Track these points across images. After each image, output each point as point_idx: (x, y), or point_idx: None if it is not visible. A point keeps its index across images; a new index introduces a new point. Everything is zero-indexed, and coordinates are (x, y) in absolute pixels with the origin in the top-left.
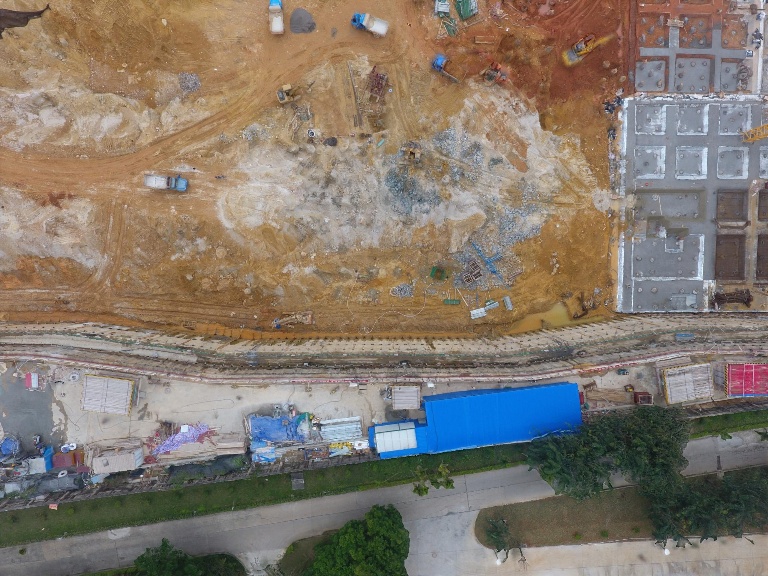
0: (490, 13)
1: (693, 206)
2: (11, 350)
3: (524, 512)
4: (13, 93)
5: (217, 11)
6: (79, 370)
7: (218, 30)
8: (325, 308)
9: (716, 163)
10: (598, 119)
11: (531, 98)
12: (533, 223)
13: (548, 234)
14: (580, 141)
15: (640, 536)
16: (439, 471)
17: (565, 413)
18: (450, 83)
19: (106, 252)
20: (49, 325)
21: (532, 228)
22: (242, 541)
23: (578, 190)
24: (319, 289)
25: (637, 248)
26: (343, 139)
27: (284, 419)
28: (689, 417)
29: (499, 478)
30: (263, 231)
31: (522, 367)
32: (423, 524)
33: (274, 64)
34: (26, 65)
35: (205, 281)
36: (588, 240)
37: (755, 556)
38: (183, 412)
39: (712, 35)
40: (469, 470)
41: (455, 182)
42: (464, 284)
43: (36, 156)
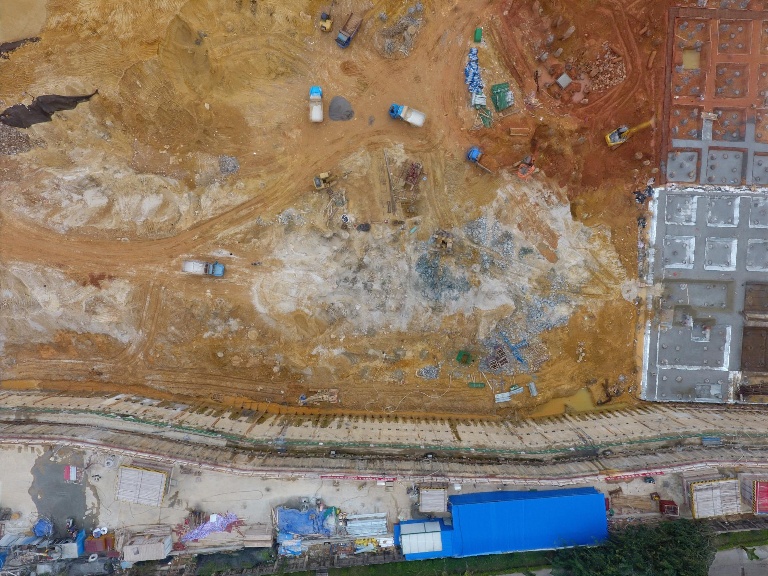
0: (525, 102)
1: (721, 296)
2: (49, 434)
3: None
4: (59, 174)
5: (259, 97)
6: (113, 456)
7: (259, 115)
8: (351, 386)
9: (745, 255)
10: (628, 208)
11: (563, 187)
12: (561, 314)
13: (576, 325)
14: (610, 232)
15: None
16: (462, 571)
17: (591, 523)
18: (484, 173)
19: (141, 328)
20: (83, 400)
21: (560, 318)
22: None
23: (607, 282)
24: (346, 368)
25: (663, 336)
26: (376, 225)
27: (311, 513)
28: (715, 532)
29: None
30: (295, 317)
31: (547, 465)
32: None
33: (312, 150)
34: (72, 145)
35: (235, 359)
36: (615, 330)
37: None
38: (212, 501)
39: (746, 129)
40: (492, 572)
41: (485, 269)
42: (489, 368)
43: (79, 238)
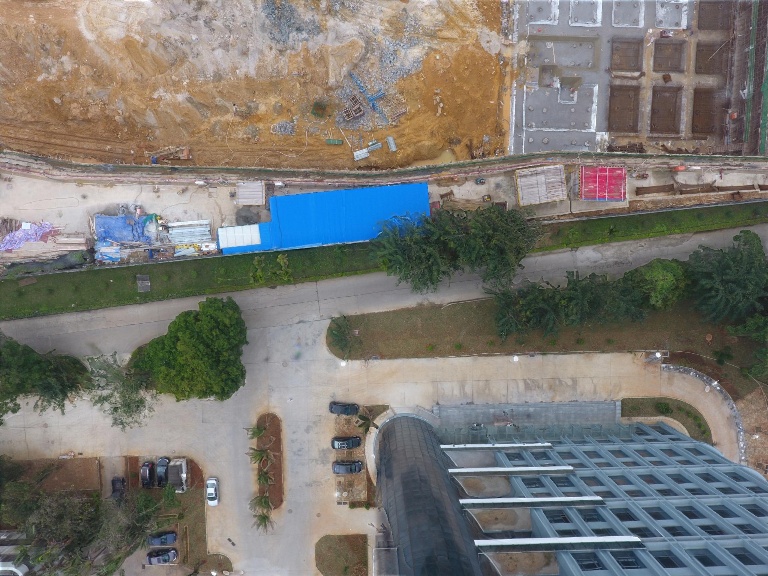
0: None
1: (587, 55)
2: None
3: (377, 322)
4: None
5: None
6: None
7: None
8: (204, 145)
9: (611, 10)
10: None
11: None
12: (414, 55)
13: (429, 67)
14: None
15: (495, 351)
16: None
17: (413, 212)
18: None
19: None
20: None
21: (413, 61)
22: (86, 344)
23: (462, 24)
24: (196, 123)
25: (529, 98)
26: None
27: (129, 218)
28: (542, 221)
29: (352, 287)
30: (126, 45)
31: None
32: (273, 332)
33: None
34: None
35: (74, 106)
36: (473, 80)
37: (613, 375)
38: (26, 209)
39: None
40: (319, 276)
41: (335, 12)
42: (346, 123)
43: None
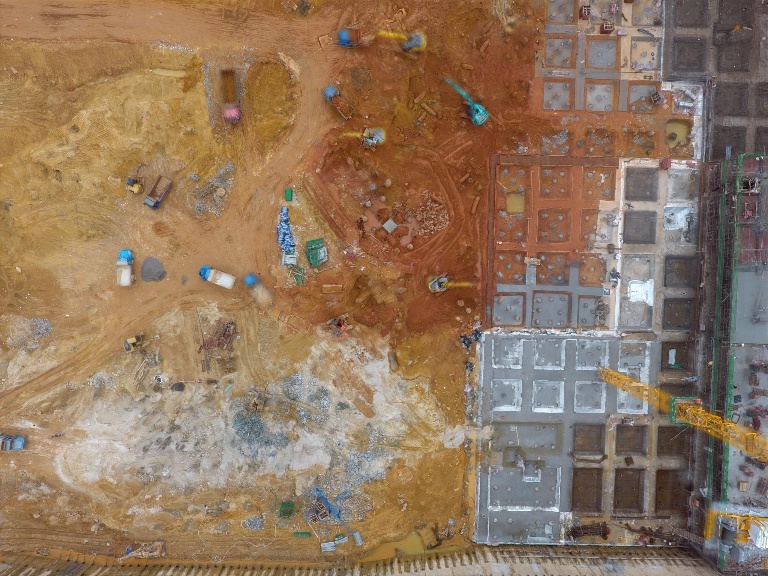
0: (347, 251)
1: (551, 437)
2: None
3: None
4: None
5: (71, 259)
6: None
7: (71, 277)
8: (177, 537)
9: (573, 397)
10: (455, 352)
11: (385, 336)
12: (377, 469)
13: (392, 480)
14: (429, 384)
15: None
16: None
17: None
18: None
19: None
20: None
21: (377, 472)
22: None
23: (425, 434)
24: (169, 521)
25: (494, 477)
26: (190, 385)
27: None
28: None
29: None
30: (101, 485)
31: None
32: None
33: (125, 311)
34: None
35: (52, 519)
36: (437, 480)
37: None
38: None
39: (569, 273)
40: None
41: (303, 424)
42: None
43: None
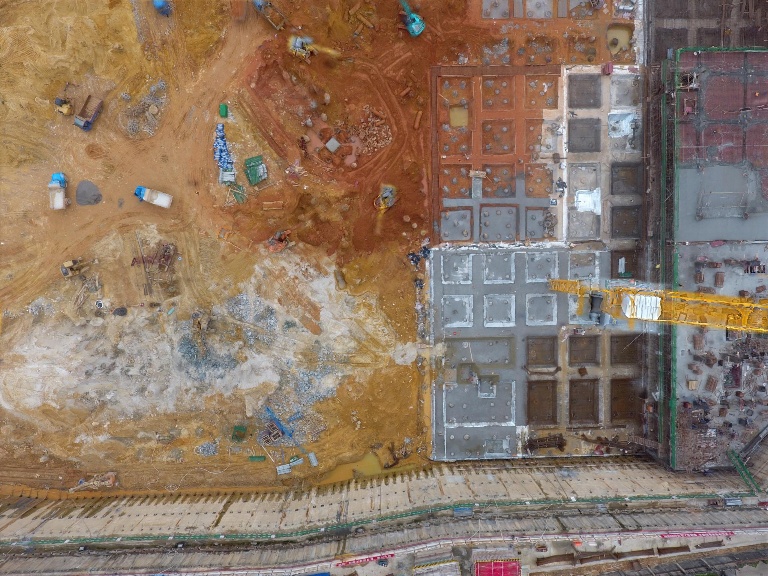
0: (289, 171)
1: (504, 352)
2: None
3: None
4: None
5: (3, 185)
6: None
7: (4, 204)
8: (130, 467)
9: (524, 310)
10: (404, 270)
11: (331, 255)
12: (327, 386)
13: (343, 396)
14: (377, 299)
15: None
16: None
17: None
18: None
19: None
20: None
21: (328, 390)
22: None
23: (375, 350)
24: (121, 451)
25: (449, 395)
26: (132, 309)
27: None
28: None
29: None
30: (44, 411)
31: (295, 549)
32: None
33: (61, 236)
34: None
35: None
36: (389, 396)
37: None
38: None
39: (515, 185)
40: None
41: (250, 345)
42: None
43: None
